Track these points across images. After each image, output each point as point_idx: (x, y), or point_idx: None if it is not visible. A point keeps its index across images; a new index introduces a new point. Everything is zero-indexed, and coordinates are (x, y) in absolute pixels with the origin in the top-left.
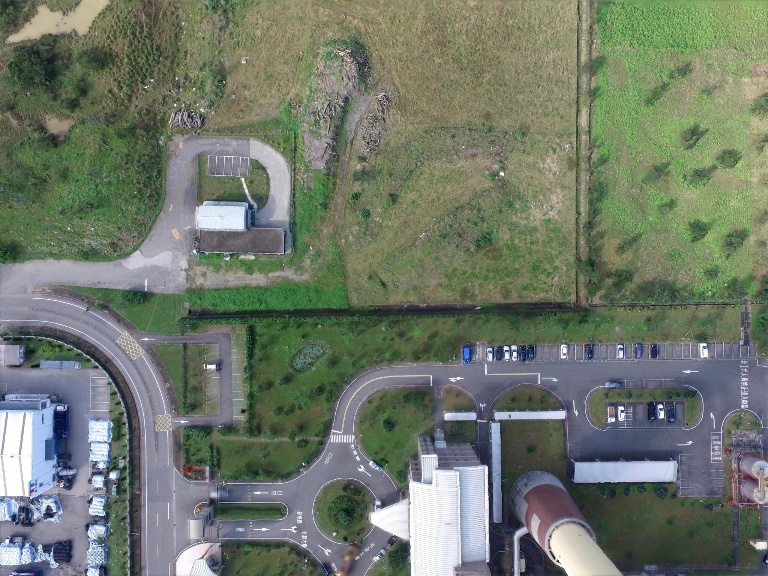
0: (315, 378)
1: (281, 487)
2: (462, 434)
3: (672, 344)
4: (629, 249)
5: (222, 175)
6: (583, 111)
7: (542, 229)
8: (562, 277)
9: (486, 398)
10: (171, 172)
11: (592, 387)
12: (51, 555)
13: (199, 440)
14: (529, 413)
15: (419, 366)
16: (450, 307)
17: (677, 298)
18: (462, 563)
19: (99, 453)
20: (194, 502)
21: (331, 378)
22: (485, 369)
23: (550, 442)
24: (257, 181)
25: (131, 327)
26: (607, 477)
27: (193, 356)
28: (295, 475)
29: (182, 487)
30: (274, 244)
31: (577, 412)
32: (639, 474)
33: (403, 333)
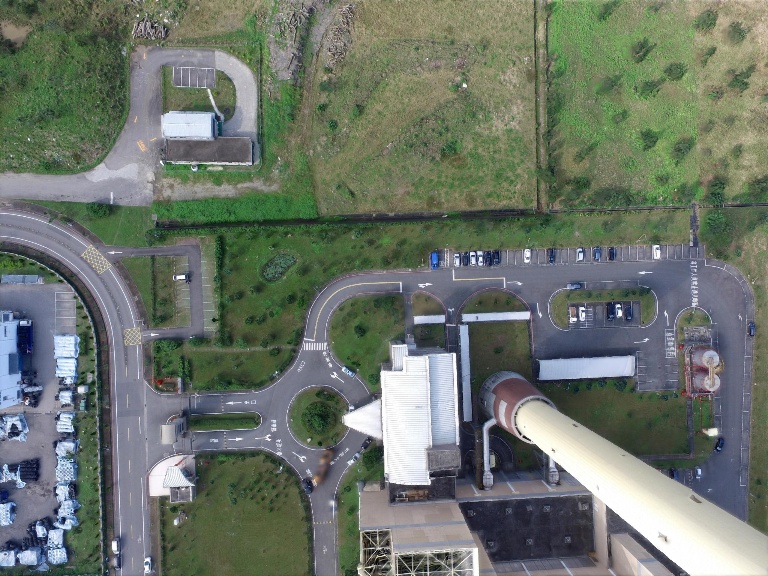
0: (286, 287)
1: (254, 396)
2: (432, 338)
3: (628, 247)
4: (586, 157)
5: (188, 86)
6: (540, 26)
7: (504, 138)
8: (524, 185)
9: (454, 303)
10: (135, 83)
11: (554, 290)
12: (17, 474)
13: (170, 351)
14: (495, 314)
15: (389, 273)
16: (418, 216)
17: (631, 202)
18: (433, 445)
19: (66, 368)
20: (166, 415)
21: (302, 287)
22: (453, 275)
23: (516, 343)
24: (223, 92)
25: (97, 240)
26: (570, 373)
27: (162, 268)
28: (268, 384)
29: (153, 400)
30: (242, 153)
31: (541, 314)
32: (600, 369)
33: (372, 241)
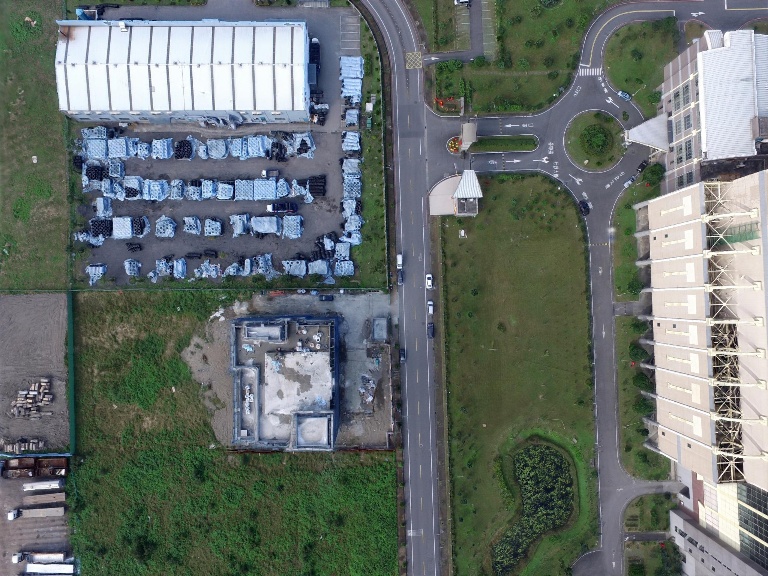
0: (563, 13)
1: (532, 120)
2: None
3: None
4: None
5: None
6: None
7: None
8: None
9: None
10: None
11: None
12: (307, 188)
13: (455, 69)
14: None
15: (662, 1)
16: None
17: None
18: None
19: (352, 88)
20: (446, 136)
21: (579, 13)
22: (725, 4)
23: None
24: None
25: None
26: None
27: None
28: (545, 108)
29: (434, 122)
30: None
31: None
32: None
33: None
